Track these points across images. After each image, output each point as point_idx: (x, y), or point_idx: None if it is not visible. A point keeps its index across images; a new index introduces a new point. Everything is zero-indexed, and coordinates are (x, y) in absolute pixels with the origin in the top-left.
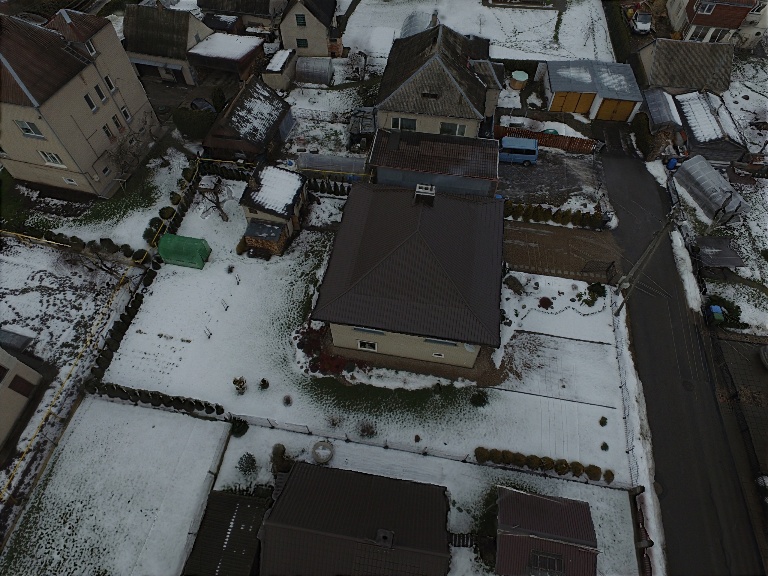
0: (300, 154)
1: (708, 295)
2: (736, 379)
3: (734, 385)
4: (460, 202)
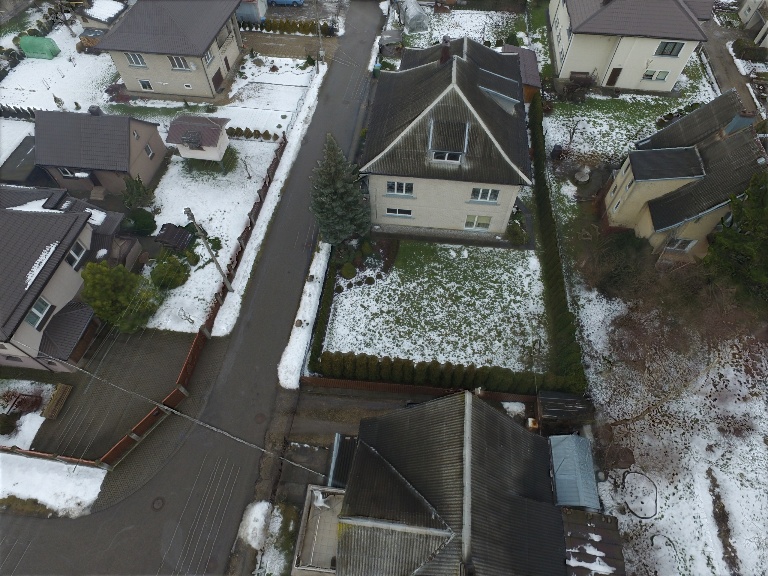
0: None
1: None
2: None
3: None
4: None
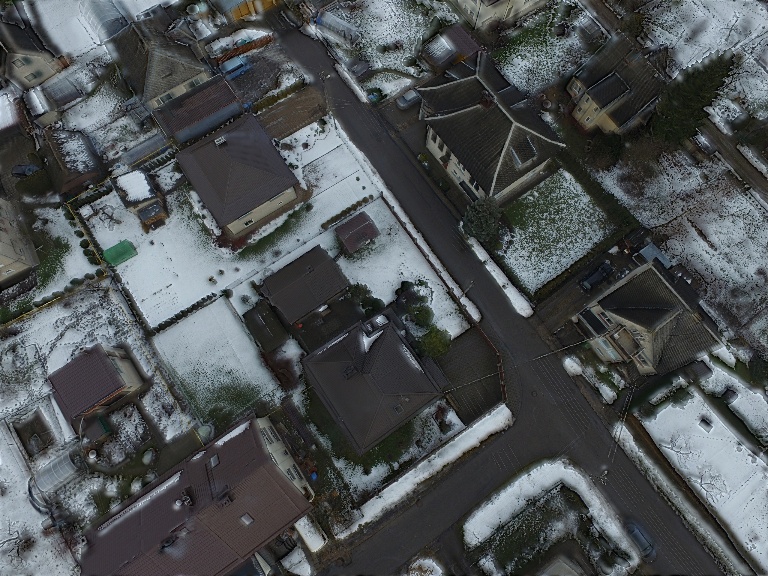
0: None
1: (366, 91)
2: (394, 123)
3: (393, 127)
4: (235, 132)
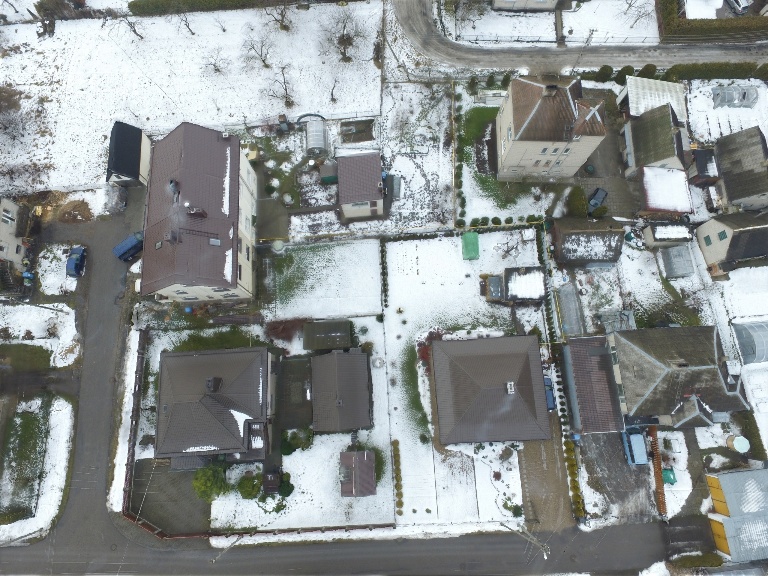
0: (569, 286)
1: None
2: None
3: None
4: (526, 409)
